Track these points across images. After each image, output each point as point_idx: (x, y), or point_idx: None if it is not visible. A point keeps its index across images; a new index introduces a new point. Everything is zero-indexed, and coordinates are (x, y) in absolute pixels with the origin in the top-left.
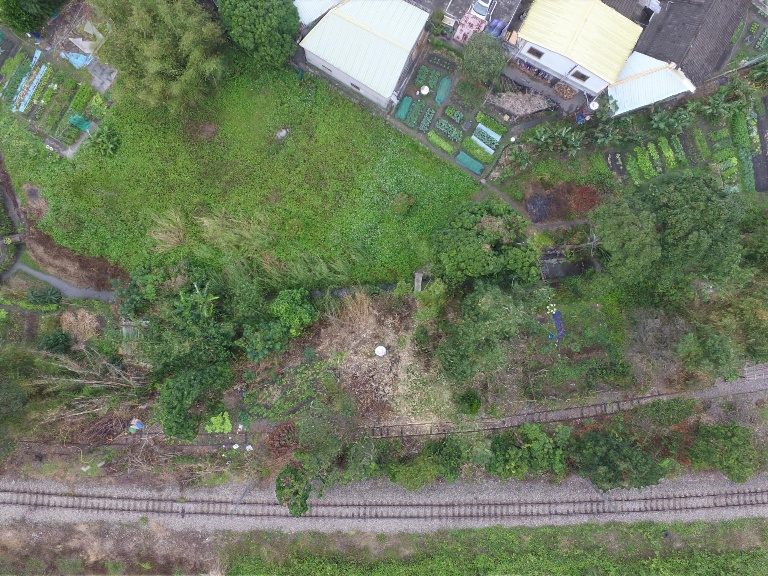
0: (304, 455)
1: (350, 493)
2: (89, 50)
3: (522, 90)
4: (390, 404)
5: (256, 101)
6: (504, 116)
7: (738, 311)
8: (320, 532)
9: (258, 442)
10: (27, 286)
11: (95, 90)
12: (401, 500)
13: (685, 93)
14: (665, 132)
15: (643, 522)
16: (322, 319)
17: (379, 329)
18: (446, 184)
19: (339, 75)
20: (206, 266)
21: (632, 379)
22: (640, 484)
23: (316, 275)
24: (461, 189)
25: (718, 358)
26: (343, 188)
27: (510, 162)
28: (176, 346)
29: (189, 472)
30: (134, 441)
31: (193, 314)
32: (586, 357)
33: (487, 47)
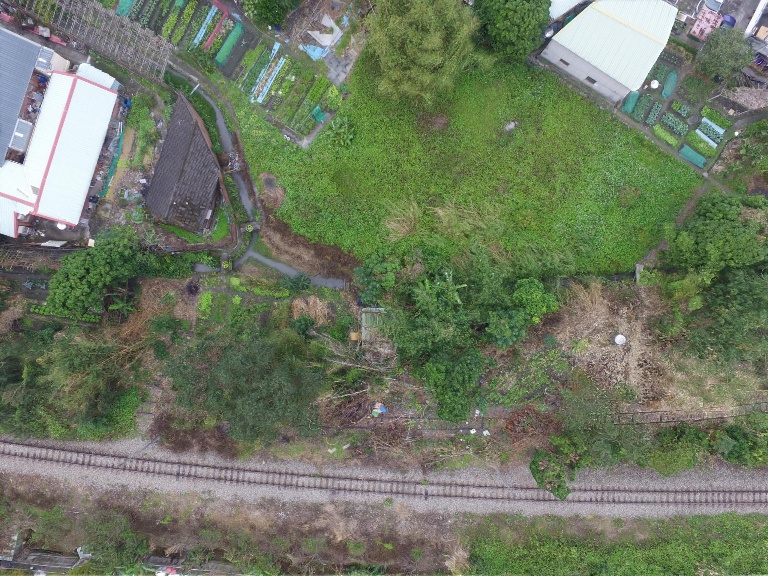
0: (561, 439)
1: (588, 478)
2: (326, 43)
3: (754, 85)
4: (622, 392)
5: (487, 94)
6: (729, 110)
7: None
8: (558, 516)
9: (495, 427)
10: (259, 273)
11: (330, 82)
12: (638, 486)
13: None
14: None
15: None
16: None
17: (612, 318)
18: (669, 177)
19: (578, 69)
20: (435, 255)
21: None
22: None
23: (546, 265)
24: (684, 182)
25: None
26: (569, 180)
27: (734, 156)
28: (441, 331)
29: (432, 455)
30: (375, 424)
31: (442, 301)
32: None
33: (737, 42)
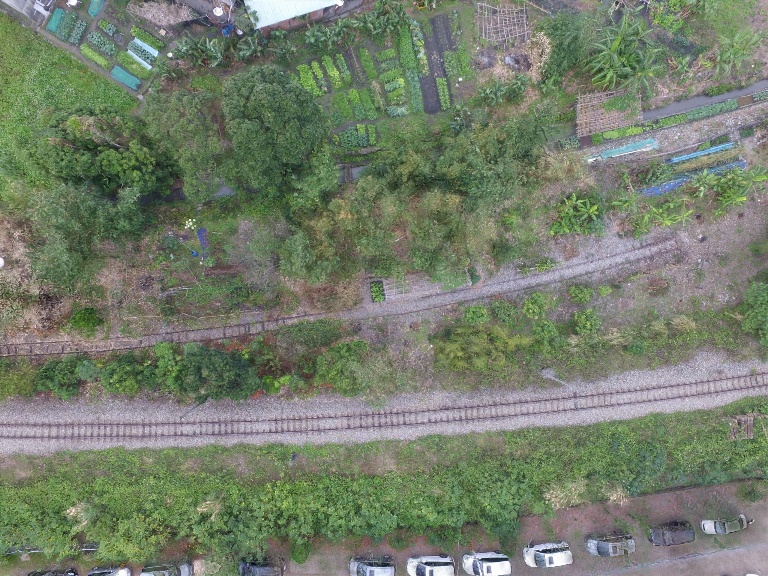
0: None
1: None
2: None
3: (167, 1)
4: (18, 321)
5: None
6: (160, 30)
7: (331, 214)
8: None
9: None
10: None
11: None
12: (17, 419)
13: (349, 12)
14: (329, 51)
15: (272, 444)
16: None
17: (10, 243)
18: (101, 99)
19: None
20: None
21: (276, 298)
22: (237, 396)
23: None
24: (116, 104)
25: (292, 258)
26: None
27: None
28: None
29: None
30: None
31: None
32: (220, 273)
33: None
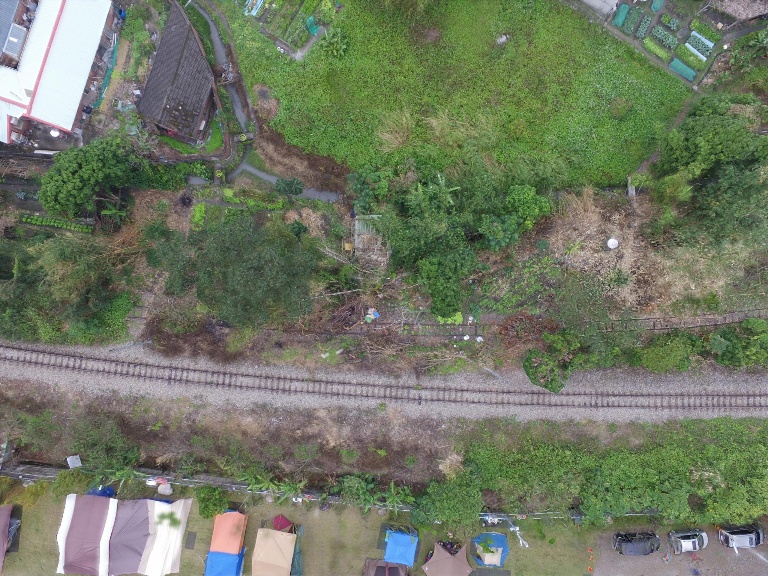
0: (554, 336)
1: (582, 383)
2: None
3: None
4: (615, 299)
5: (479, 7)
6: (717, 24)
7: None
8: (552, 421)
9: (488, 333)
10: (252, 185)
11: None
12: (632, 390)
13: None
14: None
15: None
16: (547, 216)
17: (604, 226)
18: (659, 90)
19: None
20: None
21: None
22: None
23: (538, 175)
24: (674, 95)
25: None
26: (561, 93)
27: (723, 69)
28: (434, 227)
29: (425, 360)
30: (369, 331)
31: (435, 204)
32: None
33: None
